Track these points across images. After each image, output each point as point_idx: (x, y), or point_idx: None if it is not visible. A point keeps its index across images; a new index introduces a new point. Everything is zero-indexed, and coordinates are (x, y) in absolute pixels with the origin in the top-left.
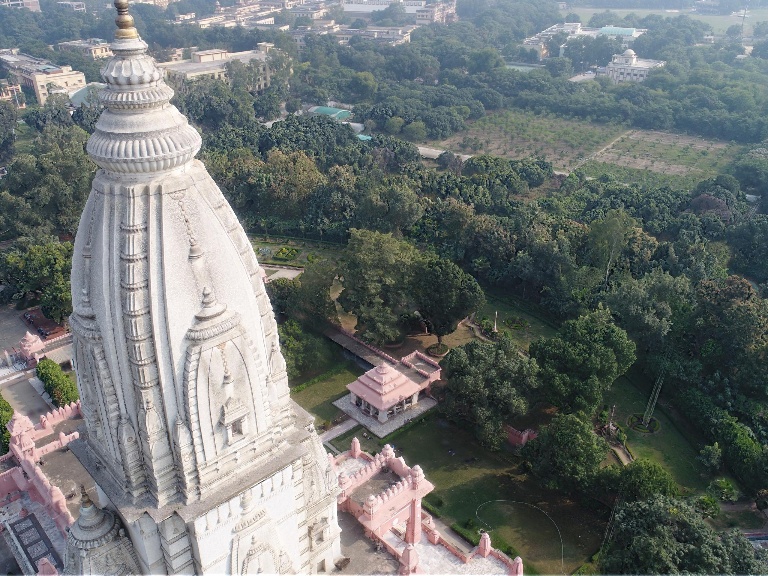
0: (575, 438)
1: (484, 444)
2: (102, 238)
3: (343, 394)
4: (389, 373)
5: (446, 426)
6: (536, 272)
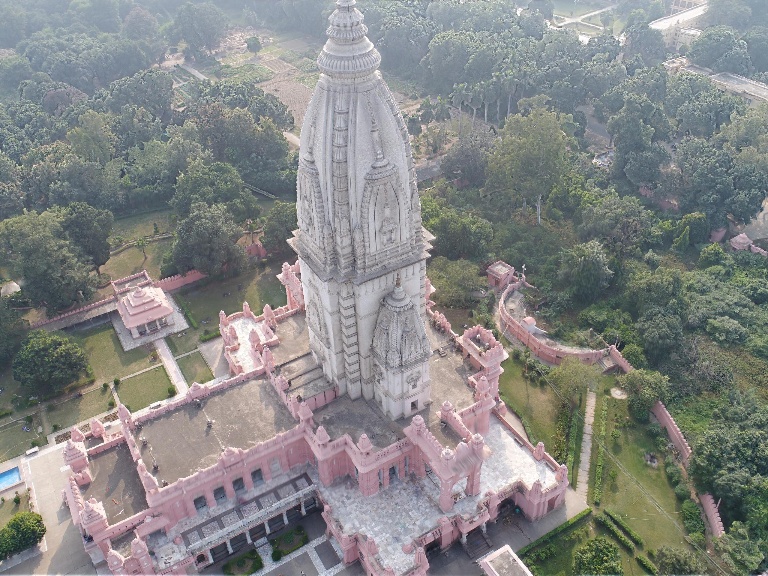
0: (294, 211)
1: (242, 270)
2: (386, 111)
3: (118, 344)
4: (146, 291)
5: (198, 293)
6: (79, 190)
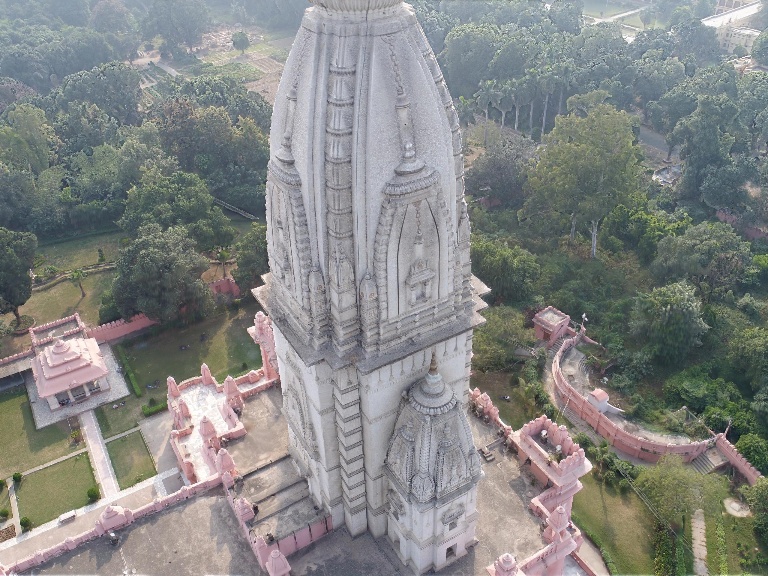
0: None
1: (206, 314)
2: (422, 72)
3: (29, 418)
4: (71, 345)
5: (147, 344)
6: (3, 206)
